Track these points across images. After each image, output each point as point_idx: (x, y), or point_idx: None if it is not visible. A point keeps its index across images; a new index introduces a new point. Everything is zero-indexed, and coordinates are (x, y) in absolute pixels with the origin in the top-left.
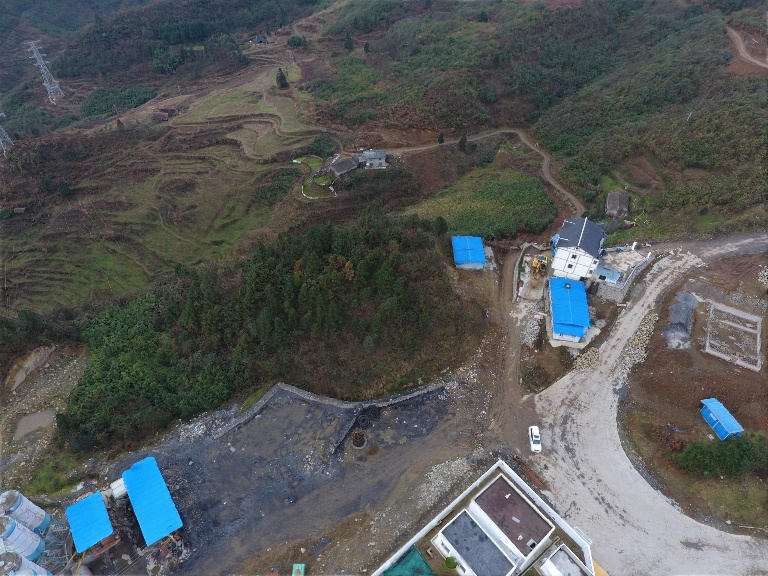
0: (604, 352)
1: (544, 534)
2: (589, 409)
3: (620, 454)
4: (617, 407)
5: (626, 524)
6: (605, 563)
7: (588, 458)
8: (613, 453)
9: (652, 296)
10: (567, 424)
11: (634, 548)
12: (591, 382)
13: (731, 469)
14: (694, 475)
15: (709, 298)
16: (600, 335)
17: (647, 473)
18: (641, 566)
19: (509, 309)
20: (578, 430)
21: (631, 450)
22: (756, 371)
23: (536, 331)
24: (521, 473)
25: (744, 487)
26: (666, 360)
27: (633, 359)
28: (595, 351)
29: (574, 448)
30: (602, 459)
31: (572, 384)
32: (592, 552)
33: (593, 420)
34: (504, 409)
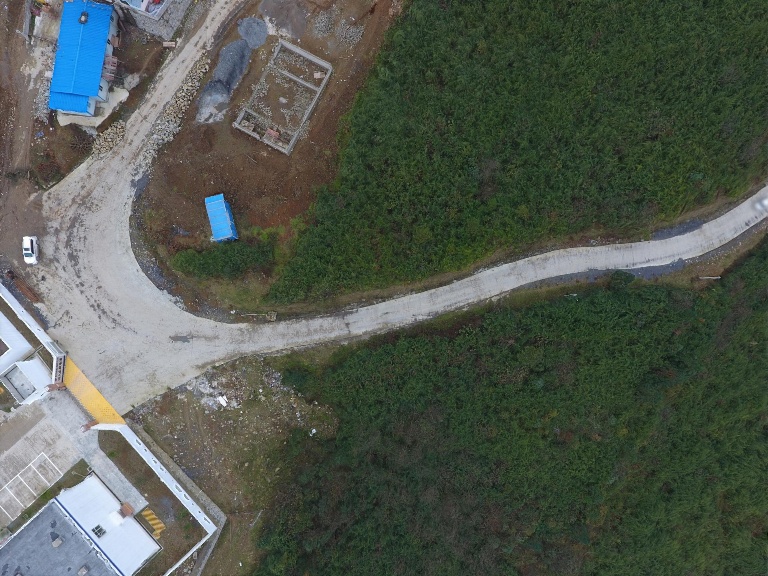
0: (132, 127)
1: (2, 354)
2: (101, 208)
3: (128, 257)
4: (133, 203)
5: (116, 327)
6: (82, 364)
7: (91, 265)
8: (120, 257)
9: (213, 26)
10: (74, 228)
11: (117, 348)
12: (108, 172)
13: (220, 273)
14: (192, 277)
15: (285, 27)
16: (132, 99)
17: (156, 274)
18: (118, 363)
19: (20, 60)
20: (85, 234)
21: (143, 251)
22: (285, 153)
23: (46, 99)
24: (15, 287)
25: (245, 284)
26: (182, 143)
27: (160, 137)
28: (118, 127)
29: (78, 255)
30: (107, 265)
31: (87, 176)
32: (73, 355)
33: (103, 221)
34: (6, 214)
